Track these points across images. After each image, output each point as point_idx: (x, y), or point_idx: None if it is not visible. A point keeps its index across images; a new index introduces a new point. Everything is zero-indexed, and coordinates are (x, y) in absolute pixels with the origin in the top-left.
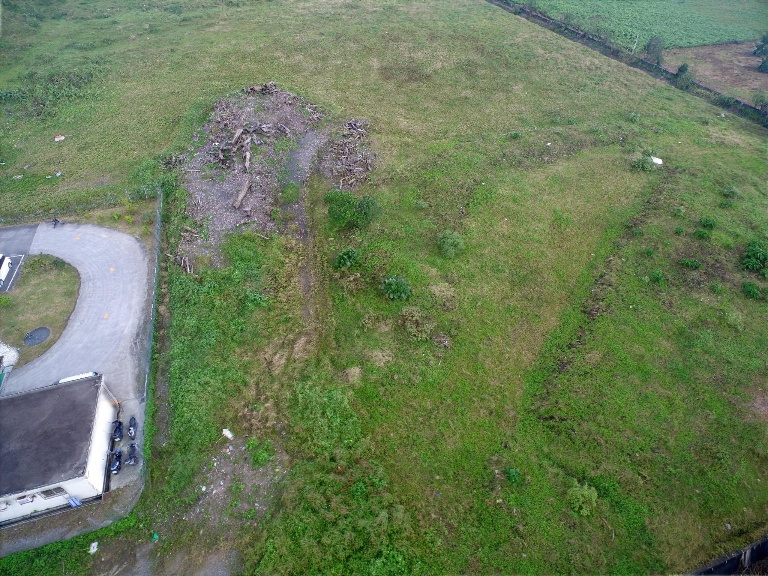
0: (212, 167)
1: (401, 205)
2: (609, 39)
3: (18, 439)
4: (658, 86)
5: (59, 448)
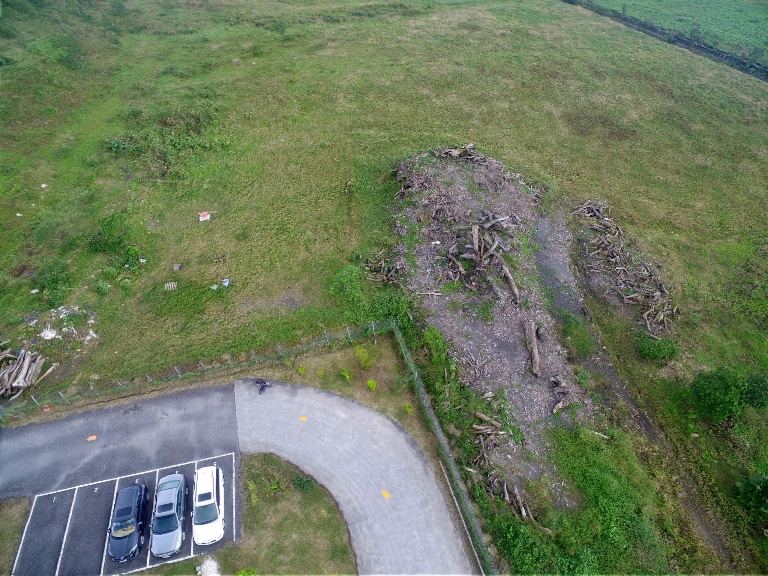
0: (455, 288)
1: (759, 367)
2: None
3: None
4: None
5: None
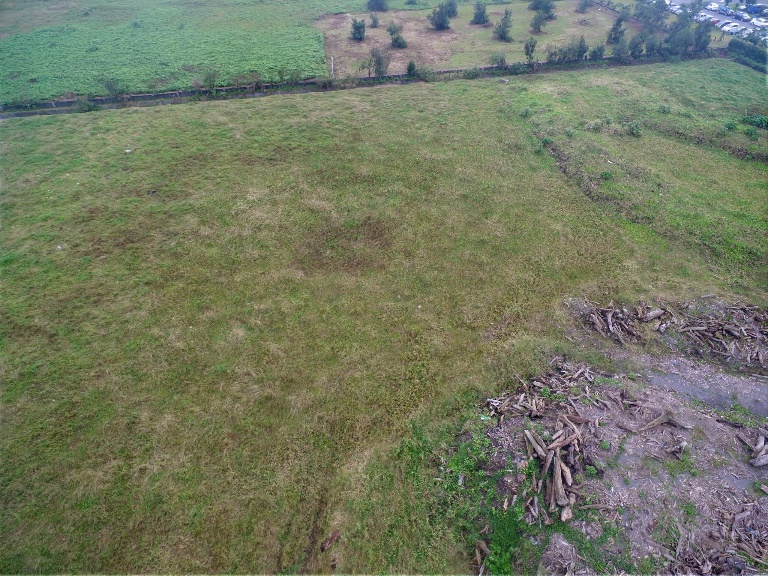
0: None
1: None
2: (299, 76)
3: None
4: (432, 87)
5: None
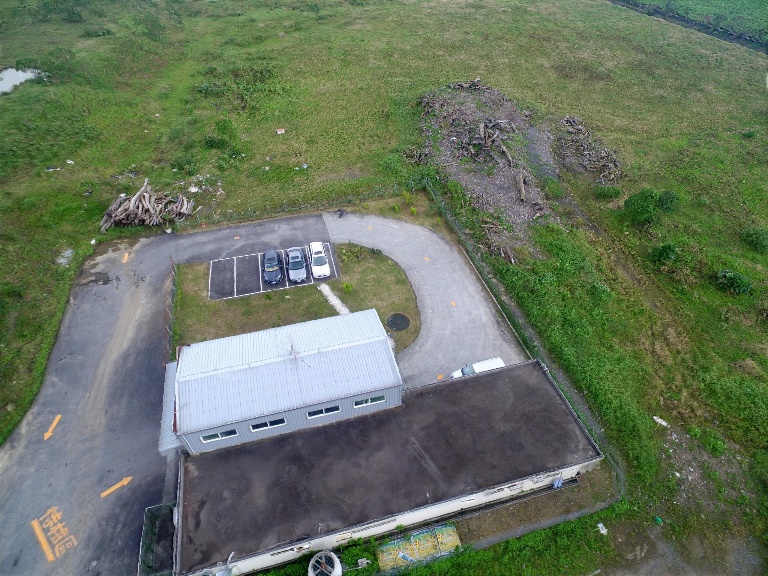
0: (468, 161)
1: None
2: None
3: (503, 420)
4: None
5: (551, 429)
